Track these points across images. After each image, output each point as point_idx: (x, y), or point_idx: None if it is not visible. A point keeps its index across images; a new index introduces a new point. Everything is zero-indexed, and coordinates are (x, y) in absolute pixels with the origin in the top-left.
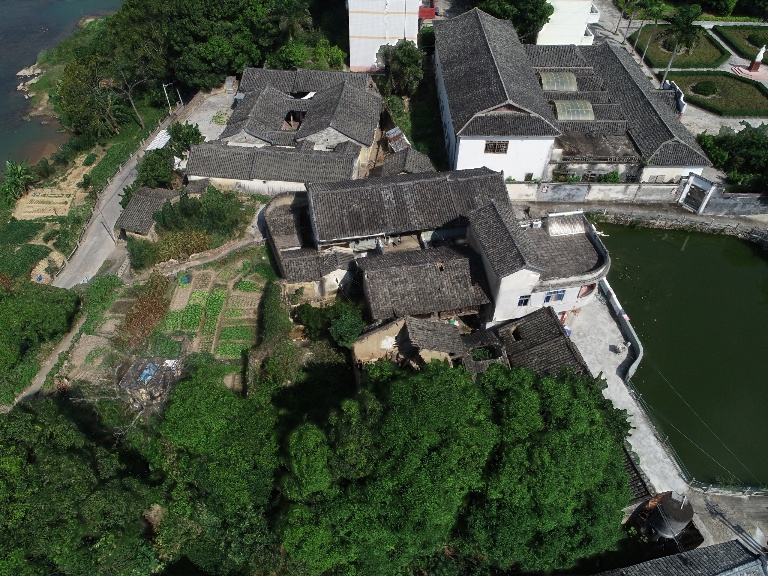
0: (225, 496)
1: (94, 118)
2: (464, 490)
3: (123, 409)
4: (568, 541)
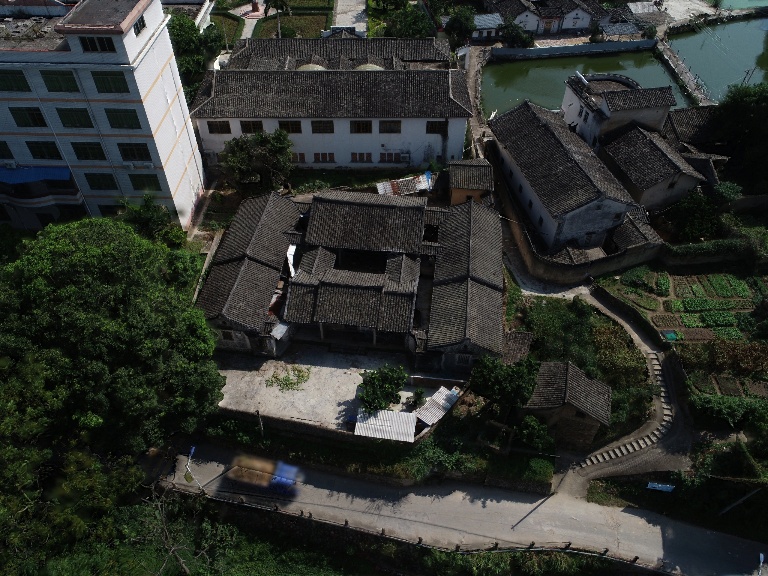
0: None
1: None
2: None
3: None
4: None
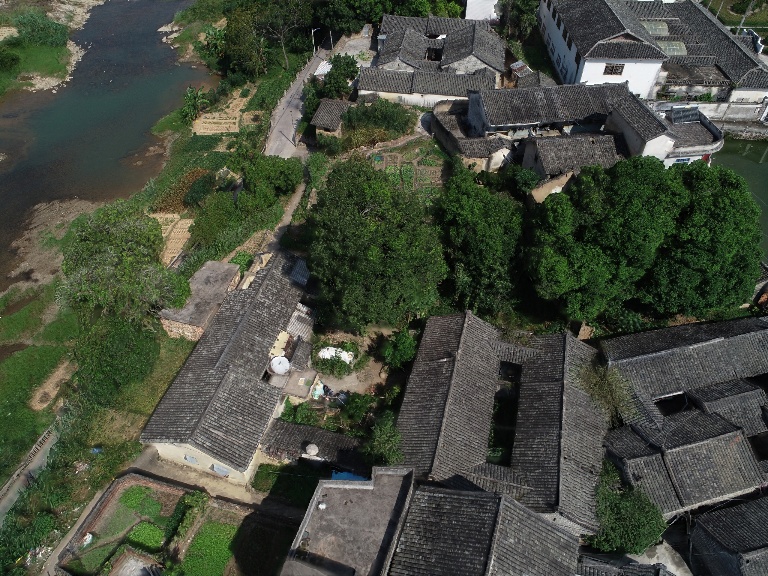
0: (487, 250)
1: (252, 57)
2: (662, 237)
3: None
4: (725, 285)
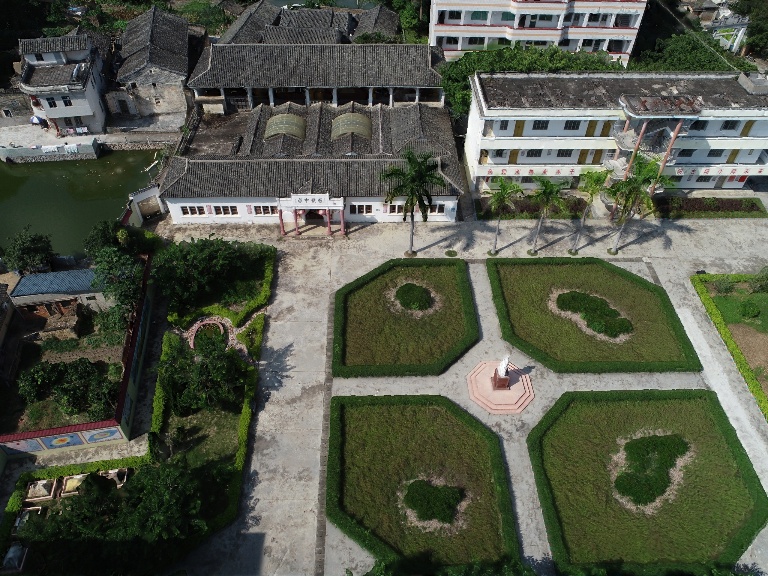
0: None
1: None
2: None
3: (61, 10)
4: None
